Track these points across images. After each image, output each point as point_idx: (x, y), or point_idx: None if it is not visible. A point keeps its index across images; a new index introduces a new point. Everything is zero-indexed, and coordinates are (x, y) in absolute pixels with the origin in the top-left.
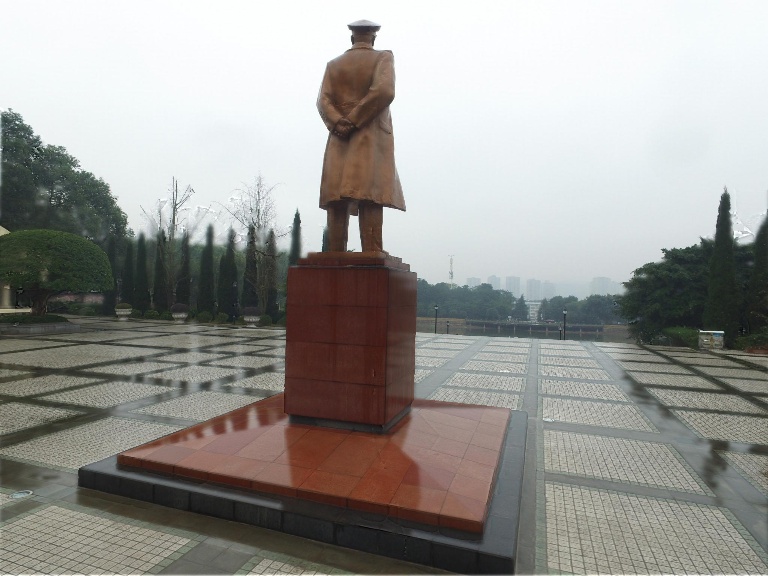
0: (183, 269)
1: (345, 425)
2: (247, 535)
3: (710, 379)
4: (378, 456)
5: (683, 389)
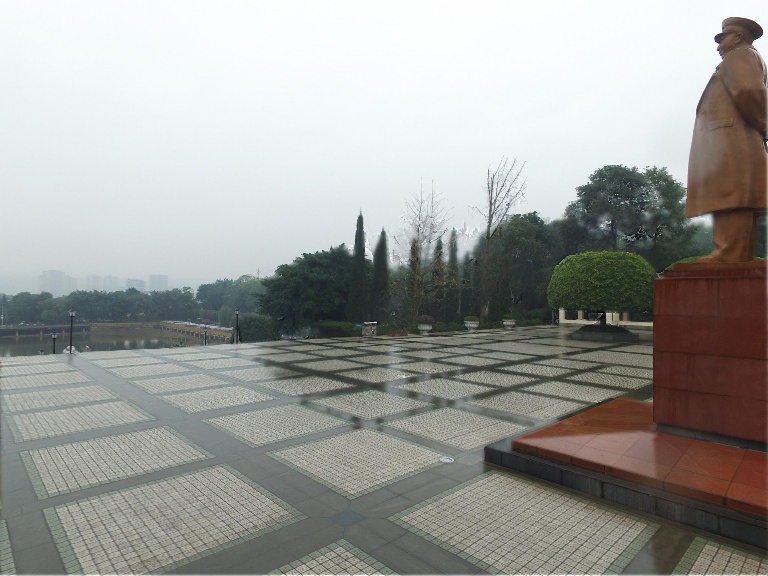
0: None
1: None
2: None
3: None
4: None
5: (503, 365)
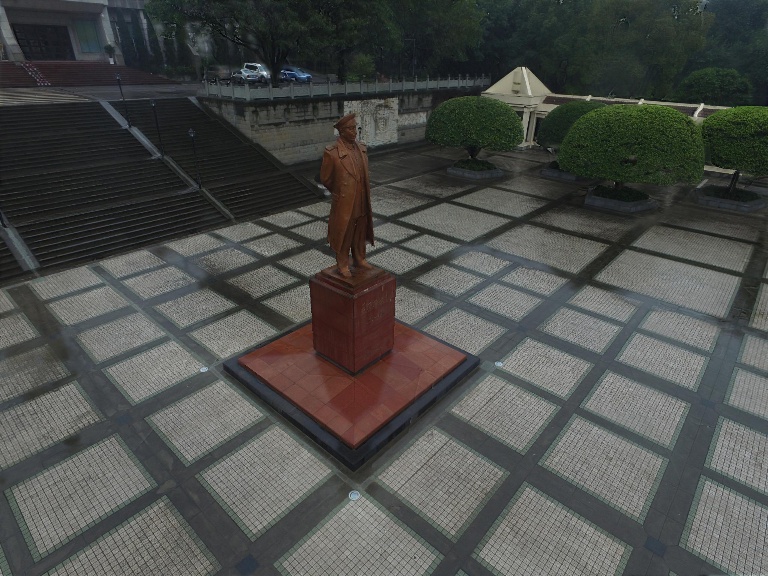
0: None
1: None
2: None
3: None
4: (297, 348)
5: None
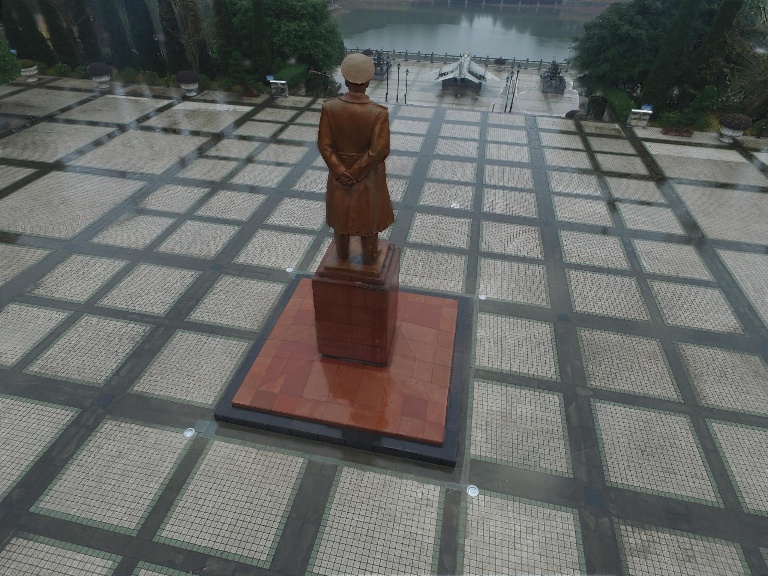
0: (76, 4)
1: (360, 361)
2: (329, 451)
3: (611, 206)
4: (385, 391)
5: (585, 229)
